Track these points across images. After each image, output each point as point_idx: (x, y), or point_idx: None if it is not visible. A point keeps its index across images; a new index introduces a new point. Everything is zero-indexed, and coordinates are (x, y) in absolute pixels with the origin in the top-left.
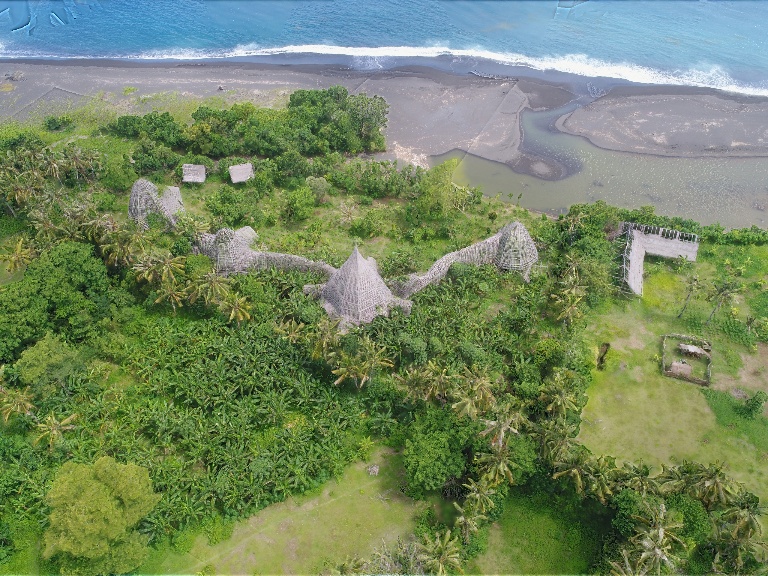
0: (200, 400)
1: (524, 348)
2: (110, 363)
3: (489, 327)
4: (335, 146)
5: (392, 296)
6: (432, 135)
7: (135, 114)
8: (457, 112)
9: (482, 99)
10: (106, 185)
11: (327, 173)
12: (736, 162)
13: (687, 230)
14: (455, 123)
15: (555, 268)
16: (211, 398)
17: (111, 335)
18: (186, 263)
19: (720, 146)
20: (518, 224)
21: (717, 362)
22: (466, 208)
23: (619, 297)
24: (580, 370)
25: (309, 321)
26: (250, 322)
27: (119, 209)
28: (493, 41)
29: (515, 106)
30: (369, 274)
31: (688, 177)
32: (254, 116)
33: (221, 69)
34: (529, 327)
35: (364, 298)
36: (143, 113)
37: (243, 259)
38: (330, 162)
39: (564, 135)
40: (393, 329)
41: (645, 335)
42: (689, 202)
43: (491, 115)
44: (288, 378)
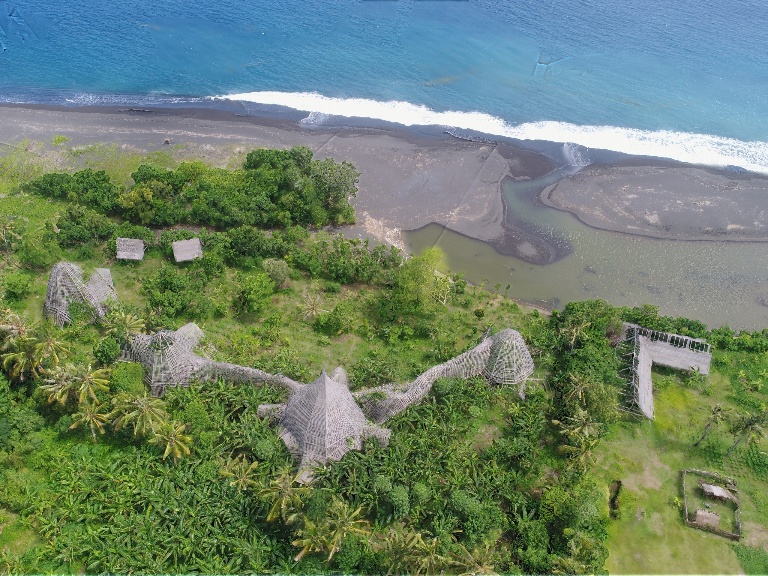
0: (120, 574)
1: (523, 487)
2: (6, 511)
3: (482, 463)
4: (297, 217)
5: (366, 423)
6: (406, 205)
7: (65, 169)
8: (433, 179)
9: (460, 164)
10: (22, 259)
11: (288, 252)
12: (734, 247)
13: (696, 335)
14: (431, 192)
15: (552, 379)
16: (134, 573)
17: (8, 476)
18: (111, 378)
19: (716, 229)
20: (513, 332)
21: (745, 507)
22: (448, 299)
23: (627, 418)
24: (594, 528)
25: (264, 458)
26: (190, 456)
27: (36, 291)
28: (469, 97)
29: (496, 174)
30: (339, 401)
31: (686, 264)
32: (205, 178)
33: (169, 117)
34: (529, 462)
35: (333, 431)
36: (74, 169)
37: (184, 369)
38: (292, 239)
39: (550, 210)
40: (367, 468)
41: (660, 469)
42: (690, 295)
43: (470, 184)
44: (236, 542)
